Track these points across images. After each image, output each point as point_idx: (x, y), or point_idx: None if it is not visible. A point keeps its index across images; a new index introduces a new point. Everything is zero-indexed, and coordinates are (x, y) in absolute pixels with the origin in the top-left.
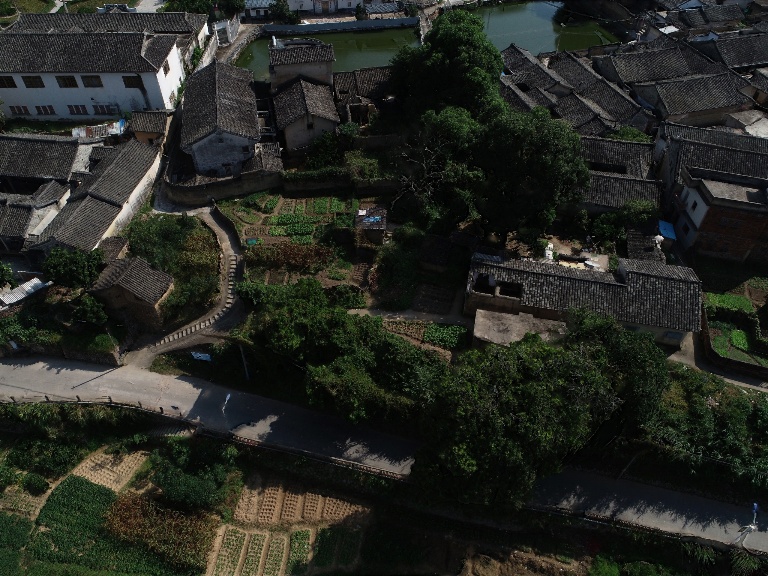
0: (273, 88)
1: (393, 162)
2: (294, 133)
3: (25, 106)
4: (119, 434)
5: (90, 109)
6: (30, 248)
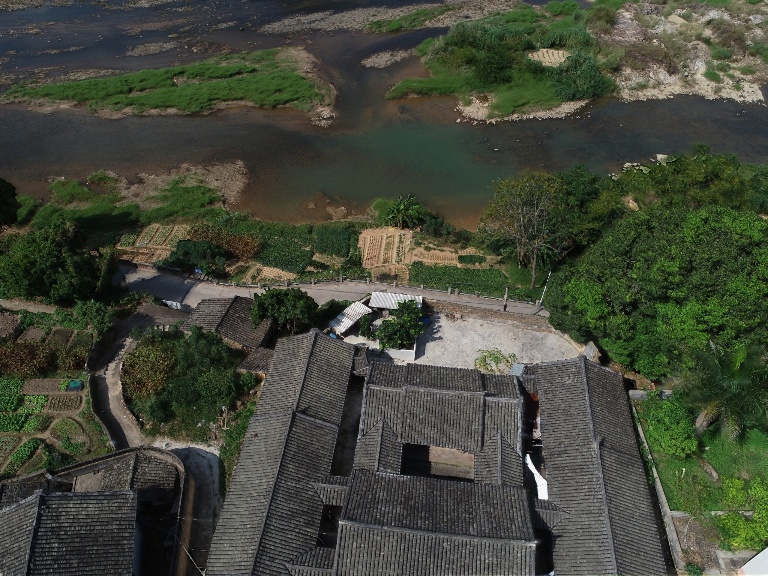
0: None
1: None
2: None
3: None
4: None
5: None
6: (353, 346)
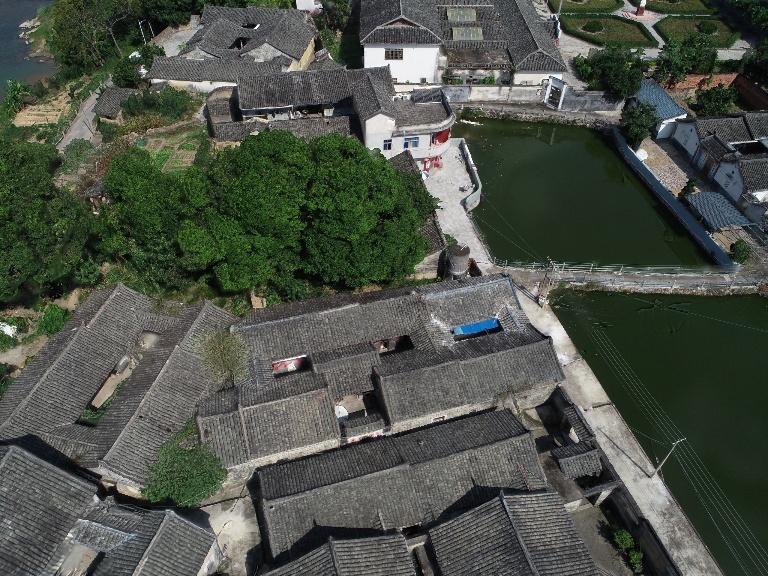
0: None
1: None
2: None
3: None
4: None
5: None
6: None
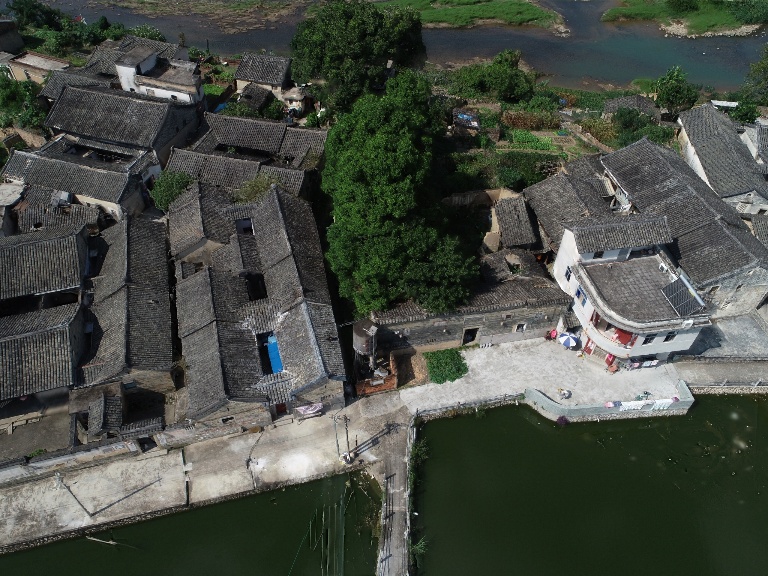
0: None
1: None
2: None
3: None
4: None
5: None
6: None
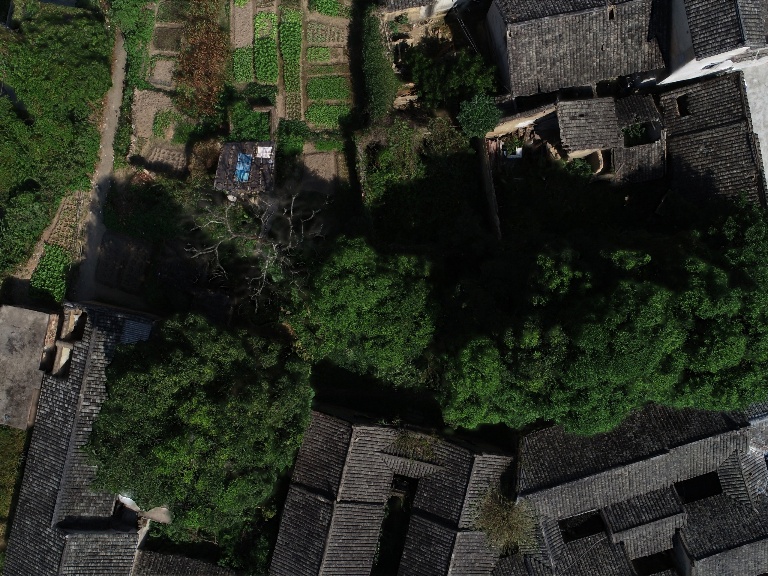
0: None
1: (431, 207)
2: None
3: None
4: None
5: None
6: None
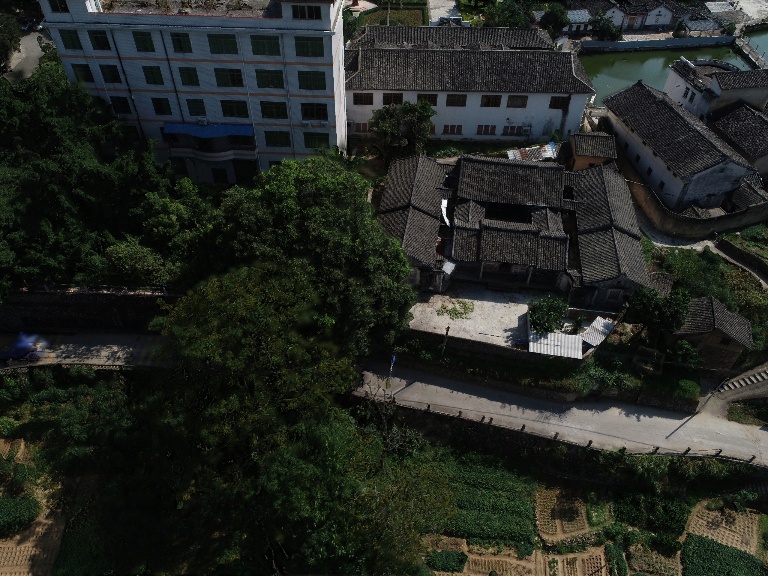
0: (708, 112)
1: None
2: (763, 162)
3: (434, 125)
4: (714, 488)
5: (499, 129)
6: (585, 284)
